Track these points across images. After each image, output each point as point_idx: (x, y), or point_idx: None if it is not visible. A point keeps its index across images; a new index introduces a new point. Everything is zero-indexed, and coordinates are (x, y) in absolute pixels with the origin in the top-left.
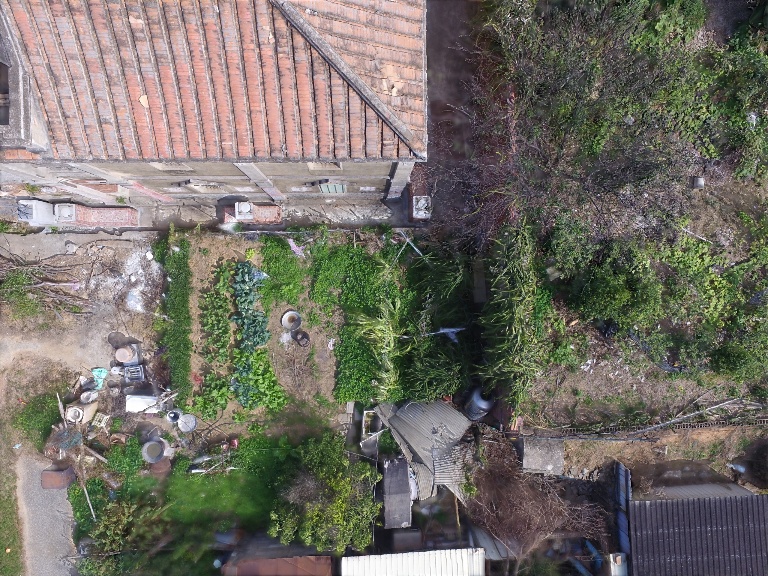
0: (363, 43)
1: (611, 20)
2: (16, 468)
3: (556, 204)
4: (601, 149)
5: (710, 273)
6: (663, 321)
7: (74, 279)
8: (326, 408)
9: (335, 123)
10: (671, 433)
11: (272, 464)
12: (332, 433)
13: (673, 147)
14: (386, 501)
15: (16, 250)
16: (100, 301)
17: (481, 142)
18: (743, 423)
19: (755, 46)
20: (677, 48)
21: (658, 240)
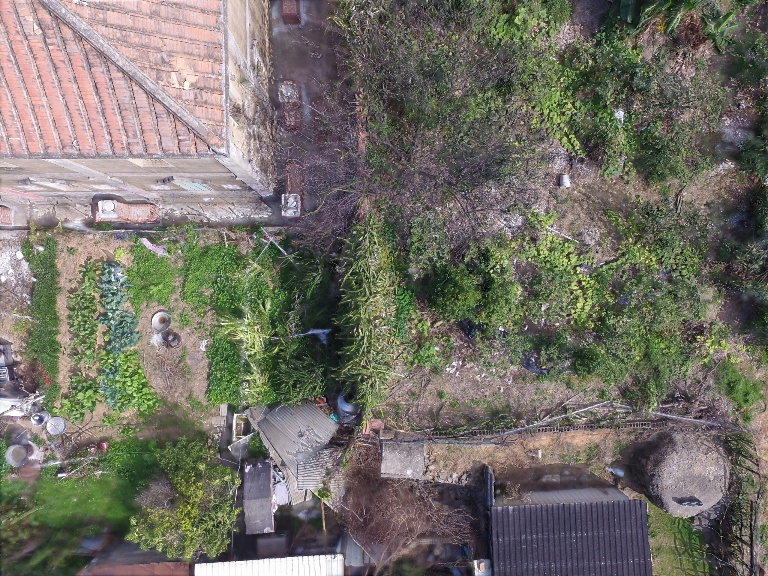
0: (147, 35)
1: (463, 13)
2: None
3: (419, 202)
4: (465, 146)
5: (578, 273)
6: (531, 322)
7: None
8: (199, 411)
9: (124, 118)
10: (543, 436)
11: (142, 468)
12: (205, 436)
13: (540, 144)
14: (245, 506)
15: None
16: None
17: (328, 138)
18: (612, 426)
19: (622, 40)
20: (530, 42)
21: (522, 239)
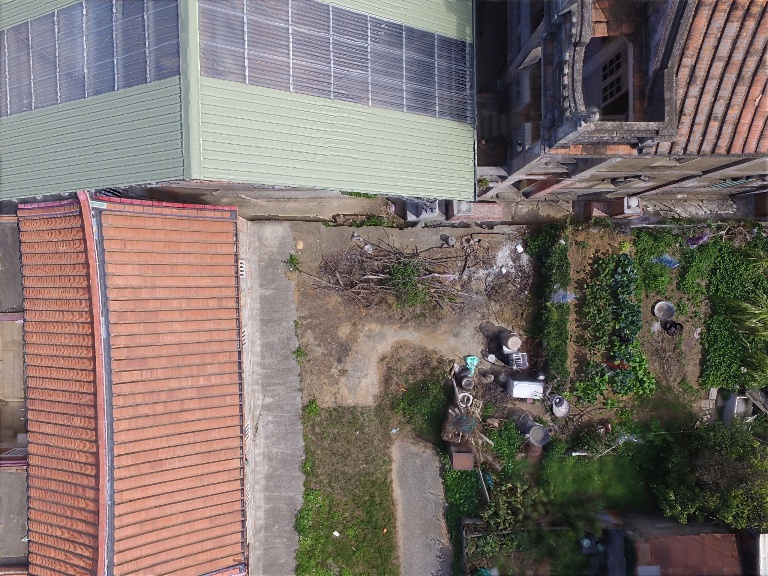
0: None
1: None
2: (392, 452)
3: None
4: None
5: None
6: None
7: (449, 271)
8: (690, 394)
9: None
10: None
11: (643, 448)
12: (696, 418)
13: None
14: None
15: (395, 243)
16: (472, 292)
17: None
18: None
19: None
20: None
21: None
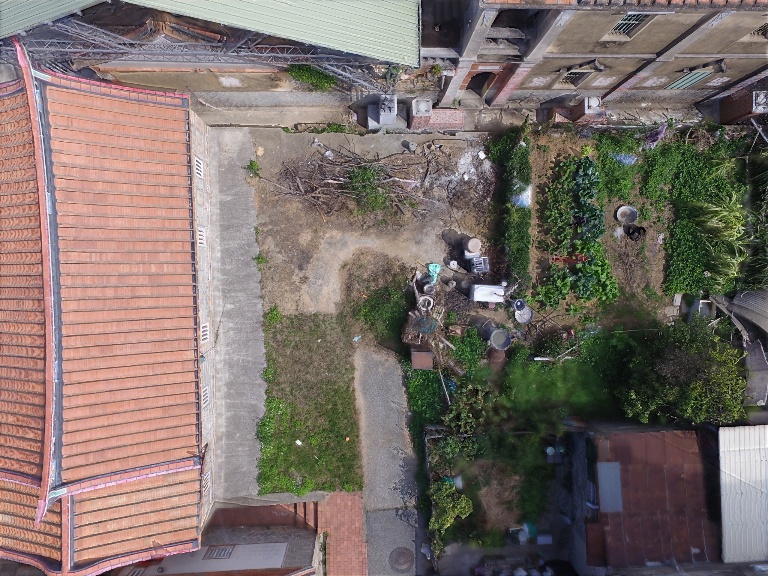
0: None
1: None
2: (354, 360)
3: None
4: None
5: None
6: None
7: (411, 177)
8: (654, 301)
9: None
10: None
11: (606, 353)
12: (660, 325)
13: None
14: (749, 378)
15: (356, 150)
16: (434, 199)
17: None
18: None
19: None
20: None
21: None
